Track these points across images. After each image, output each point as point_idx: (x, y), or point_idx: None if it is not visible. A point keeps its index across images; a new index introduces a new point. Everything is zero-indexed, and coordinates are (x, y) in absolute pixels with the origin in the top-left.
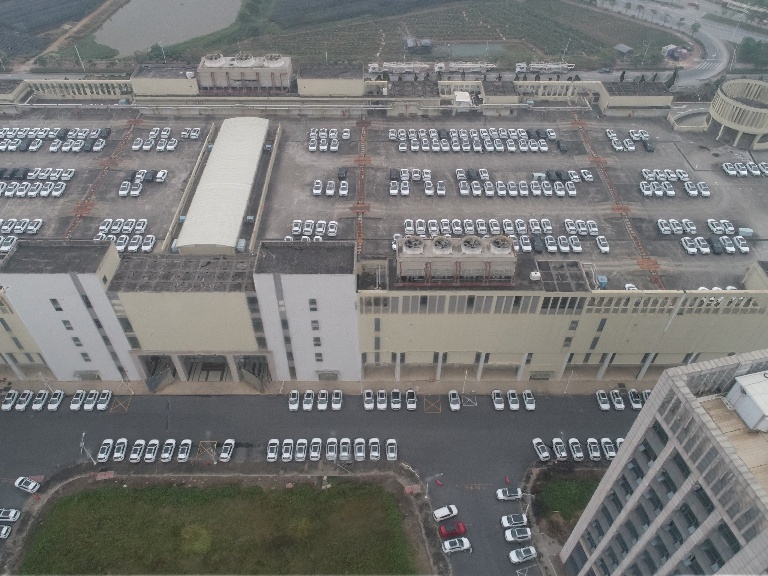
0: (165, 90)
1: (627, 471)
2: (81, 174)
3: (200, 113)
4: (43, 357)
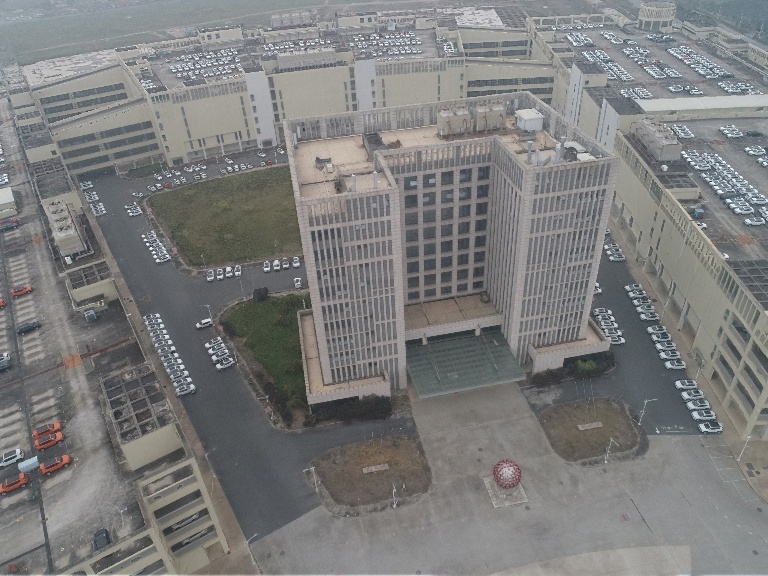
0: None
1: None
2: (681, 79)
3: None
4: None
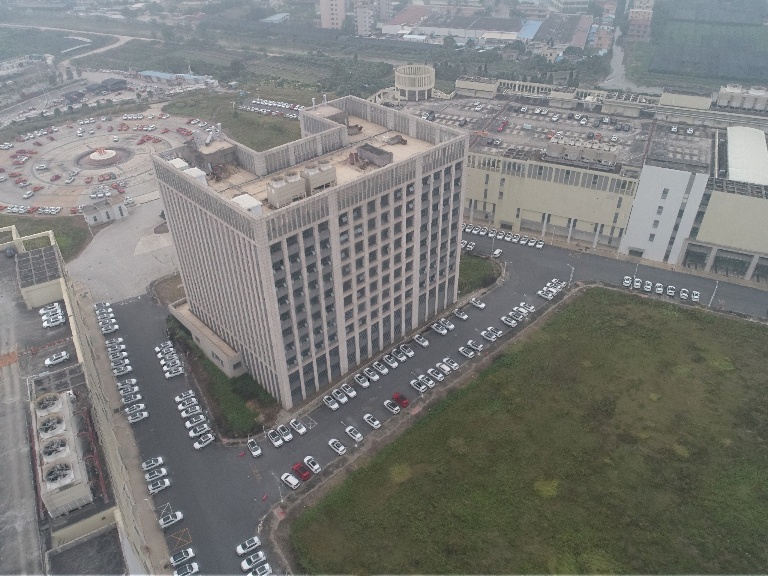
0: None
1: None
2: None
3: None
4: None
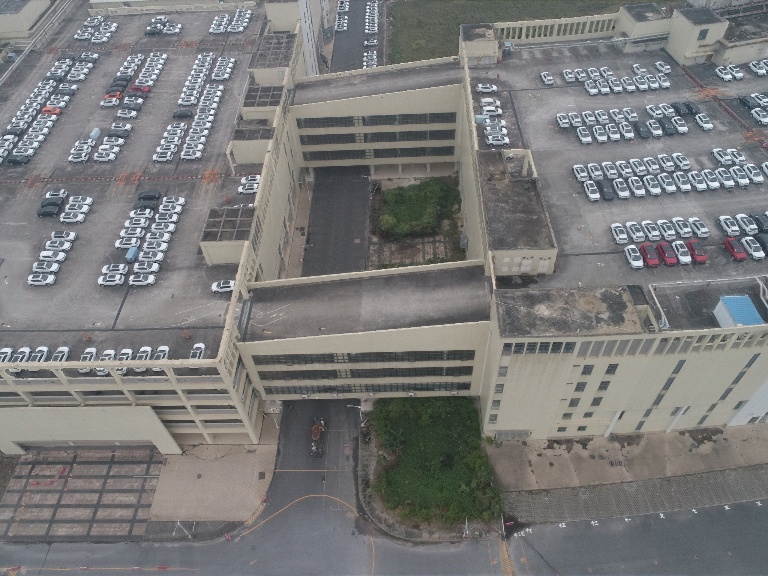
0: (36, 13)
1: None
2: None
3: (58, 23)
4: None
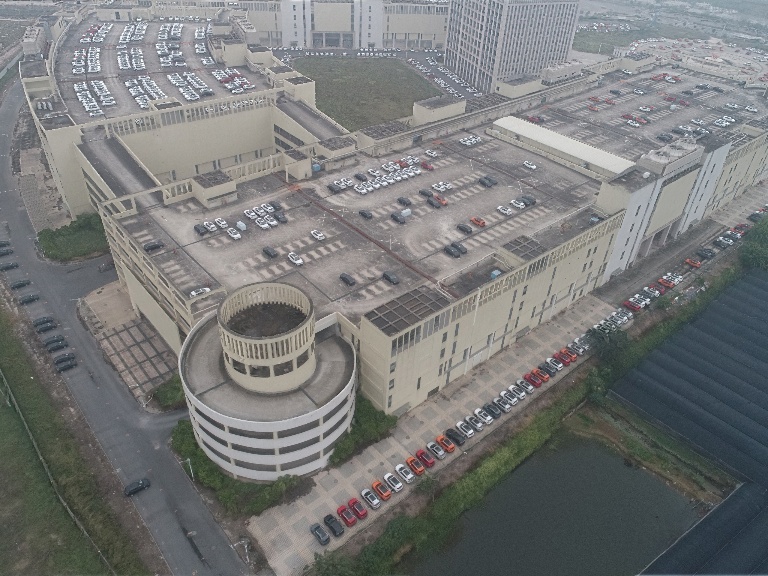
0: None
1: (451, 6)
2: None
3: None
4: (282, 34)
